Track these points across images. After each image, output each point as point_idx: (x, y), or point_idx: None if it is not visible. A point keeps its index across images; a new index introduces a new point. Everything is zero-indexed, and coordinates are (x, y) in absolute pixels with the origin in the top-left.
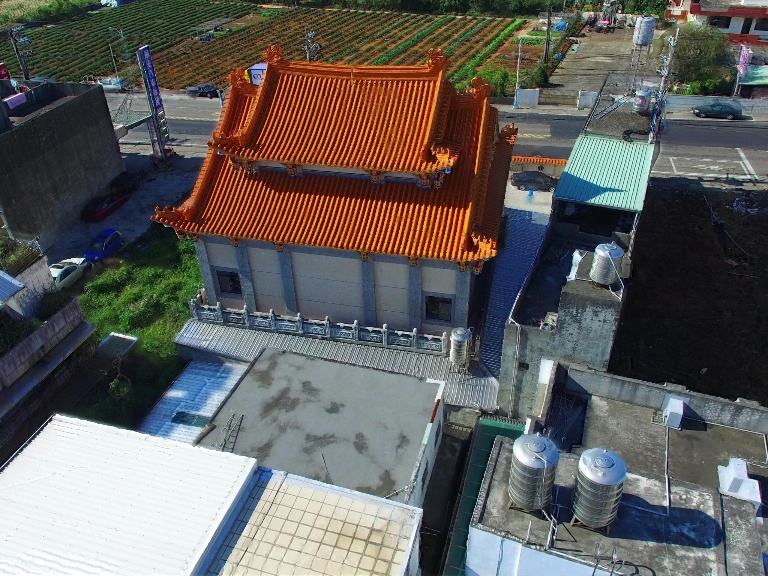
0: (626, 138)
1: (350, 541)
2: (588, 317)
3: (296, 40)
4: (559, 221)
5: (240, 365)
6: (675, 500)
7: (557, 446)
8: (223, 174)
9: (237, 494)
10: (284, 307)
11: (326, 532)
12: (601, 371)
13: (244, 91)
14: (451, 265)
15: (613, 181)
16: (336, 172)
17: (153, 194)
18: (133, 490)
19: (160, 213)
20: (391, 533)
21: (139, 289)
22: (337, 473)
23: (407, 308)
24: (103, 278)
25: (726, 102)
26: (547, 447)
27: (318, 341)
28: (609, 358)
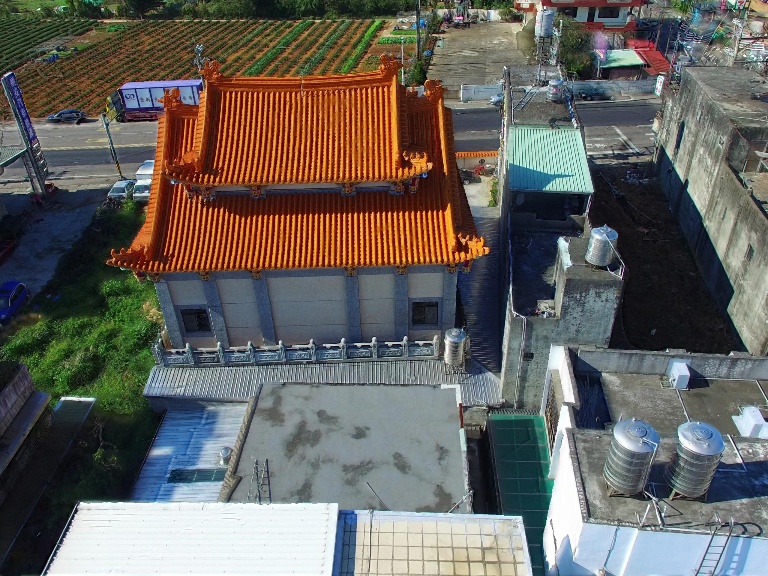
0: (553, 126)
1: (467, 566)
2: (591, 299)
3: (154, 55)
4: (515, 211)
5: (225, 407)
6: (745, 456)
7: (592, 427)
8: (176, 205)
9: (334, 545)
10: (260, 337)
11: (439, 563)
12: (609, 348)
13: (180, 113)
14: (438, 268)
15: (558, 168)
16: (302, 189)
17: (46, 236)
18: (214, 568)
19: (117, 256)
20: (503, 548)
21: (68, 344)
22: (390, 499)
23: (393, 318)
24: (19, 338)
25: (607, 85)
26: (648, 430)
27: (303, 367)
28: (610, 335)
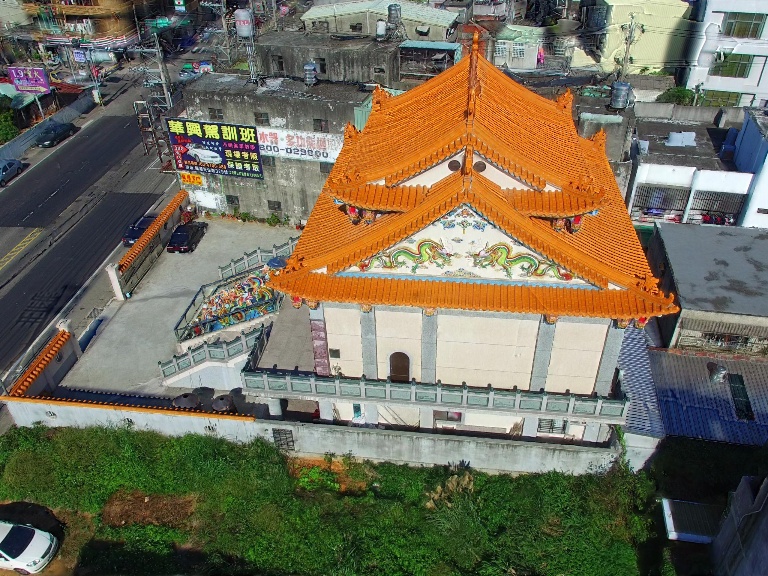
0: None
1: None
2: None
3: None
4: None
5: None
6: None
7: None
8: None
9: None
10: None
11: None
12: None
13: None
14: None
15: None
16: None
17: None
18: None
19: None
20: None
21: None
22: None
23: None
24: None
25: None
26: None
27: None
28: None
